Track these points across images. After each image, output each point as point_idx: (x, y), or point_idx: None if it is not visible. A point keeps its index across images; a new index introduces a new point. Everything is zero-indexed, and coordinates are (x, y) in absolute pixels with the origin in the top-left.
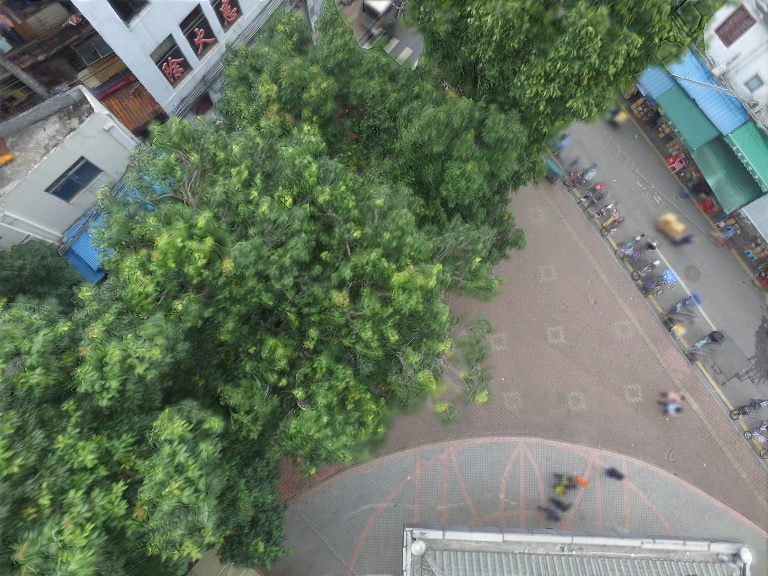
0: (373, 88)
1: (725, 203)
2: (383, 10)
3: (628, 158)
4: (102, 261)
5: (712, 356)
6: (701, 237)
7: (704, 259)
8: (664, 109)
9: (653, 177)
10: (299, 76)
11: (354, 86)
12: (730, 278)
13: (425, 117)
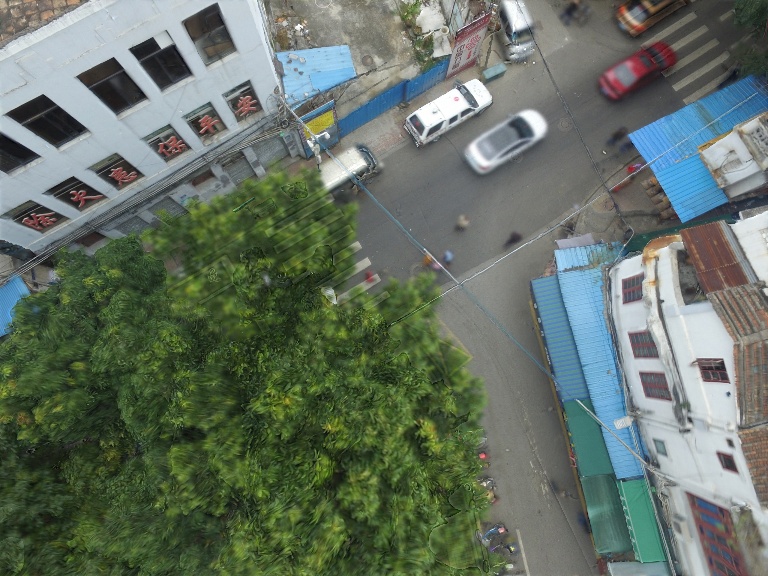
0: (124, 419)
1: (599, 541)
2: (341, 176)
3: (531, 430)
4: None
5: None
6: (574, 549)
7: (568, 575)
8: (568, 417)
9: (550, 461)
10: (36, 388)
11: (120, 394)
12: None
13: (92, 547)
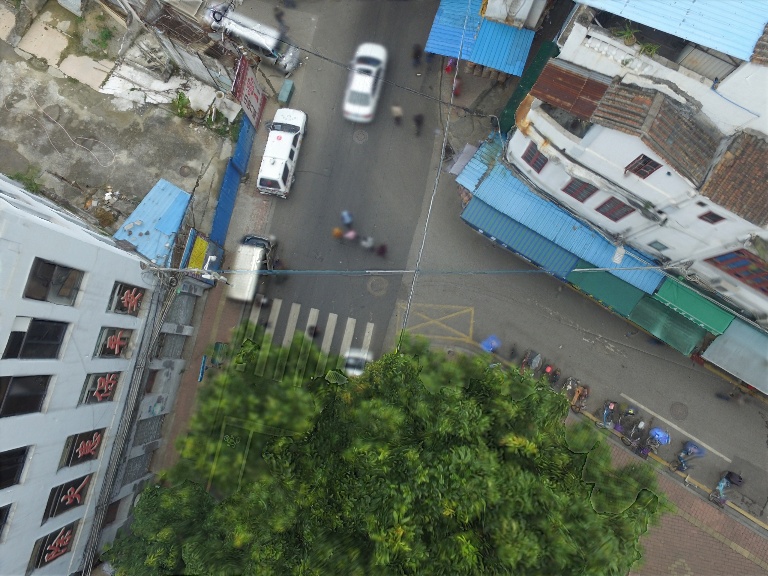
0: None
1: (681, 347)
2: (251, 274)
3: (562, 317)
4: None
5: (737, 489)
6: (670, 367)
7: (683, 389)
8: (579, 285)
9: (595, 325)
10: None
11: None
12: (717, 397)
13: None
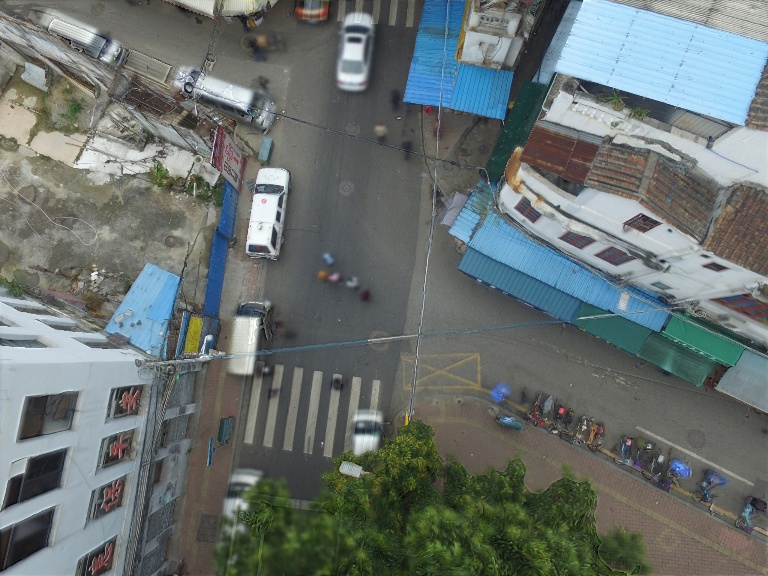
0: None
1: (693, 378)
2: None
3: (570, 354)
4: None
5: (763, 513)
6: (683, 395)
7: (698, 416)
8: (584, 328)
9: (604, 359)
10: None
11: None
12: (733, 420)
13: None
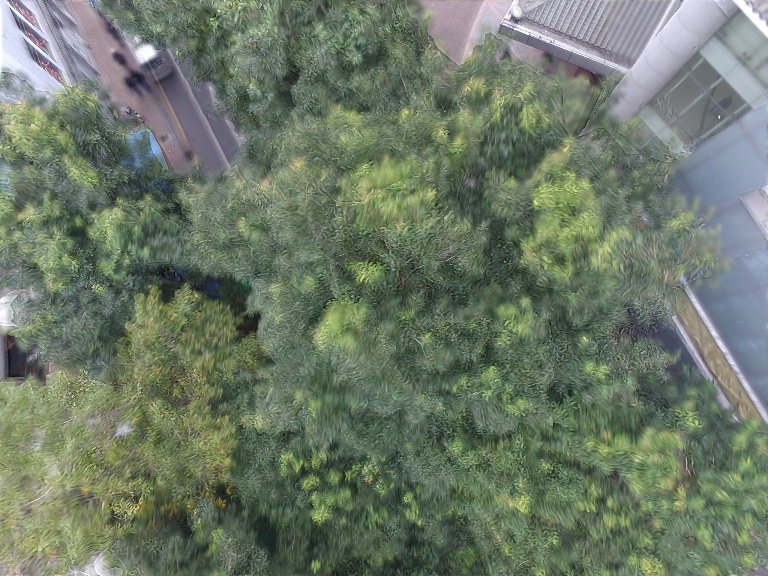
0: None
1: None
2: None
3: None
4: (190, 20)
5: None
6: None
7: None
8: None
9: None
10: None
11: None
12: None
13: None
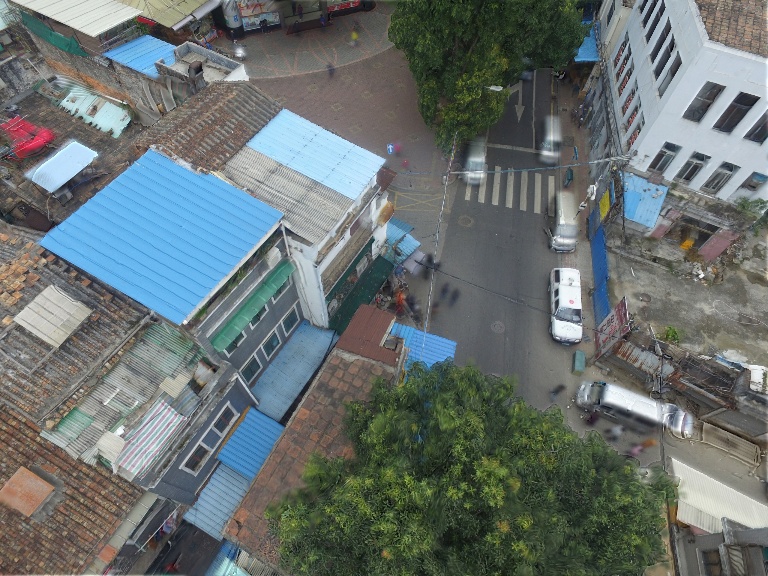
0: None
1: None
2: None
3: None
4: None
5: None
6: None
7: None
8: None
9: None
10: None
11: None
12: None
13: None
